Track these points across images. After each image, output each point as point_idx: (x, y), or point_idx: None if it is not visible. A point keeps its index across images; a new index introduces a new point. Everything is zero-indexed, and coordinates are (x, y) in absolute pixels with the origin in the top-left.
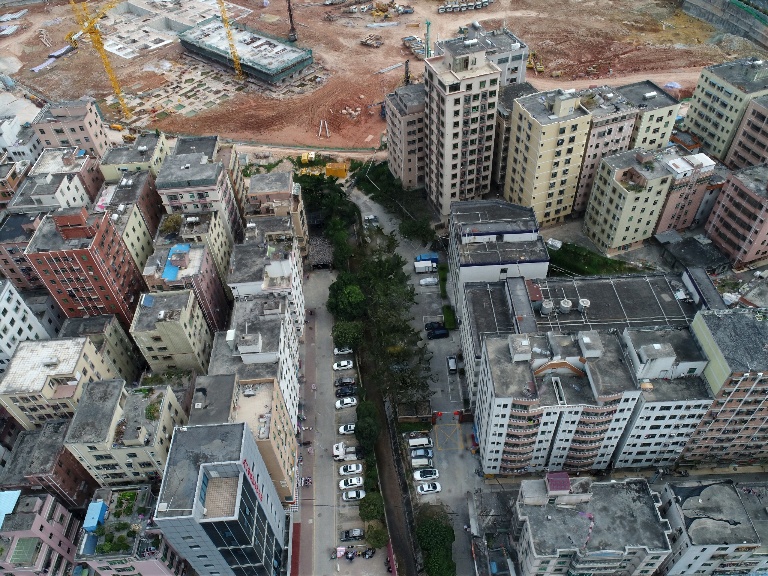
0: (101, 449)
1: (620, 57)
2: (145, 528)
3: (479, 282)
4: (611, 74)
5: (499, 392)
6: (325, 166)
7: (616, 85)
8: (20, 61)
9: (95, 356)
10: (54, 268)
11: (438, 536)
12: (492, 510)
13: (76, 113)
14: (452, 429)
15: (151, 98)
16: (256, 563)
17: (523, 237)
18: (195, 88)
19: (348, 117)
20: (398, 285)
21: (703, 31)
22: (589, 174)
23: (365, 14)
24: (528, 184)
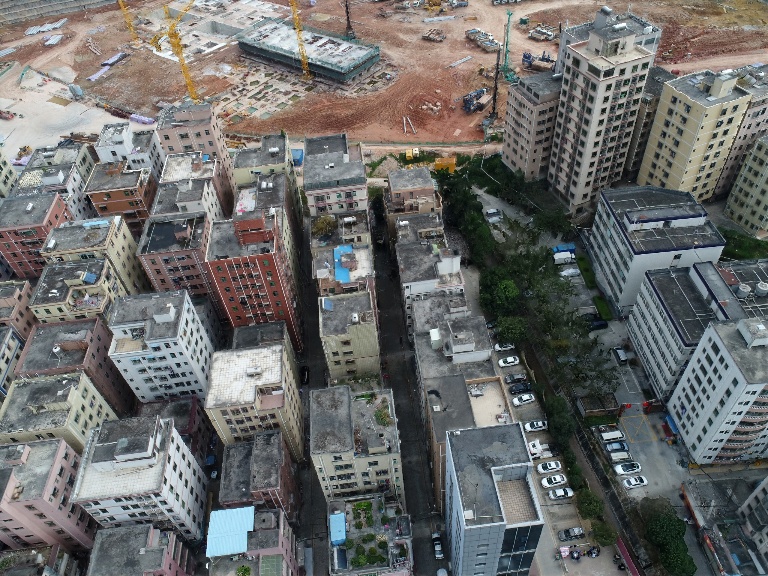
0: (346, 459)
1: (691, 41)
2: (394, 538)
3: (662, 269)
4: (689, 58)
5: (747, 379)
6: (431, 162)
7: (698, 69)
8: (74, 70)
9: (287, 364)
10: (233, 275)
11: (673, 530)
12: (712, 501)
13: (199, 117)
14: (639, 421)
15: (220, 102)
16: (523, 568)
17: (691, 222)
18: (263, 90)
19: (430, 112)
20: (554, 277)
21: (765, 12)
22: (736, 156)
23: (418, 9)
24: (677, 169)
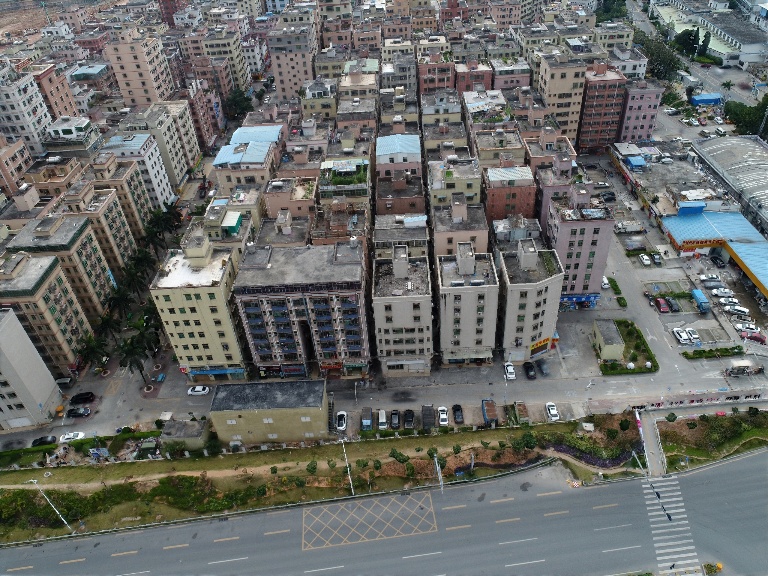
0: None
1: None
2: None
3: None
4: None
5: None
6: None
7: None
8: None
9: None
10: (182, 3)
11: None
12: None
13: None
14: None
15: None
16: None
17: None
18: None
19: None
20: None
21: (85, 5)
22: None
23: None
24: None
